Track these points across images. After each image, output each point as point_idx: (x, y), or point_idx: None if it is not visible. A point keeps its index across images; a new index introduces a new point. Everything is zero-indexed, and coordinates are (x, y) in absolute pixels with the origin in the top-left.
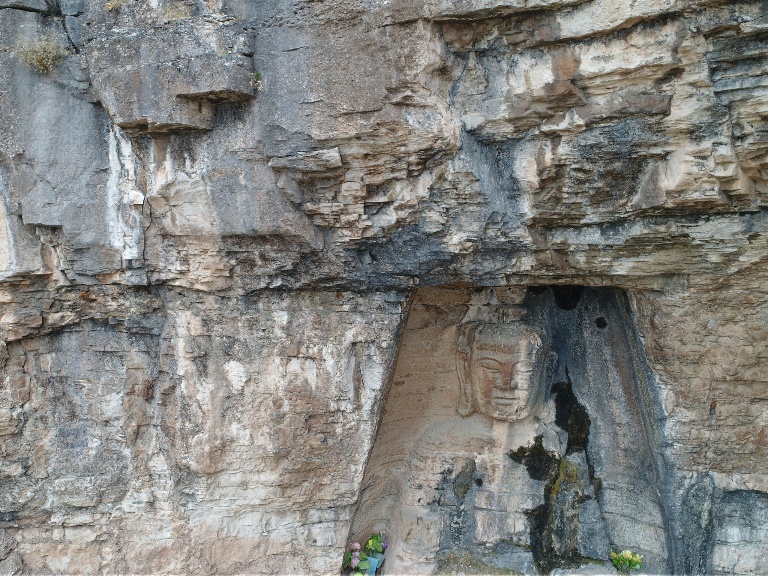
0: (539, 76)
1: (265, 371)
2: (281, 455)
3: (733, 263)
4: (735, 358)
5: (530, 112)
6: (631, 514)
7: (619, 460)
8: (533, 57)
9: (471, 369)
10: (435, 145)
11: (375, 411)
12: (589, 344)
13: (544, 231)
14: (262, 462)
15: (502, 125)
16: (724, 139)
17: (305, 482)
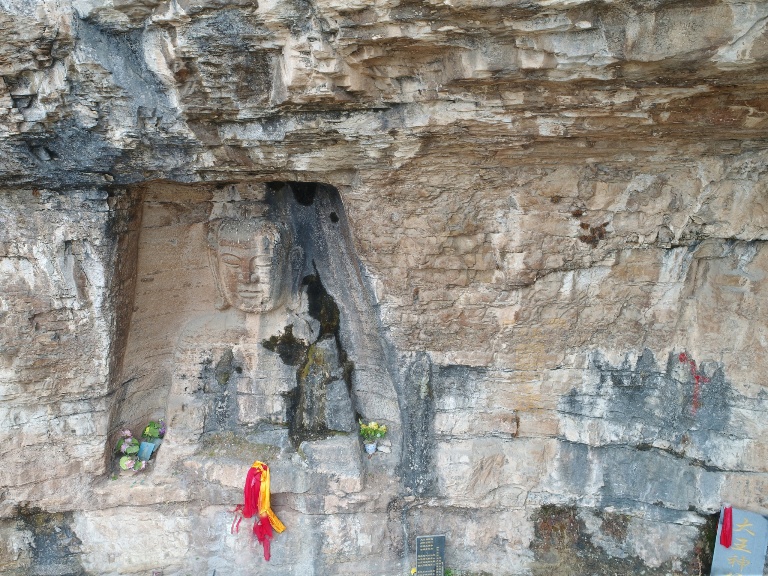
0: None
1: None
2: (9, 353)
3: (393, 158)
4: (422, 248)
5: None
6: (379, 391)
7: (366, 344)
8: None
9: (219, 265)
10: (44, 34)
11: (107, 308)
12: (328, 238)
13: (213, 127)
14: None
15: (115, 13)
16: (315, 34)
17: (47, 377)
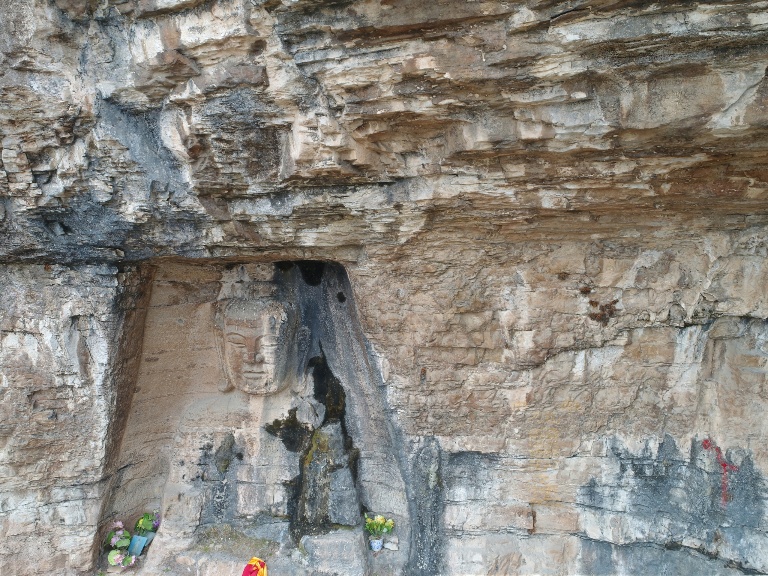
0: (152, 46)
1: None
2: (4, 432)
3: (398, 233)
4: (429, 325)
5: (153, 81)
6: (386, 481)
7: (373, 430)
8: (146, 27)
9: (224, 345)
10: (68, 112)
11: (108, 386)
12: (335, 319)
13: (223, 202)
14: None
15: (136, 94)
16: (322, 110)
17: (41, 460)
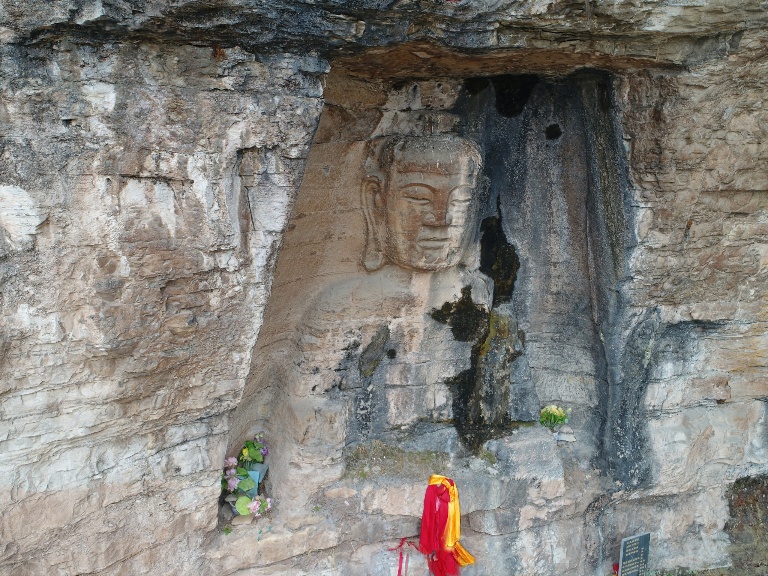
0: None
1: (78, 204)
2: (121, 351)
3: None
4: (736, 160)
5: None
6: (554, 366)
7: (547, 307)
8: None
9: (387, 203)
10: None
11: (271, 267)
12: (532, 163)
13: None
14: (85, 368)
15: None
16: None
17: (161, 389)
